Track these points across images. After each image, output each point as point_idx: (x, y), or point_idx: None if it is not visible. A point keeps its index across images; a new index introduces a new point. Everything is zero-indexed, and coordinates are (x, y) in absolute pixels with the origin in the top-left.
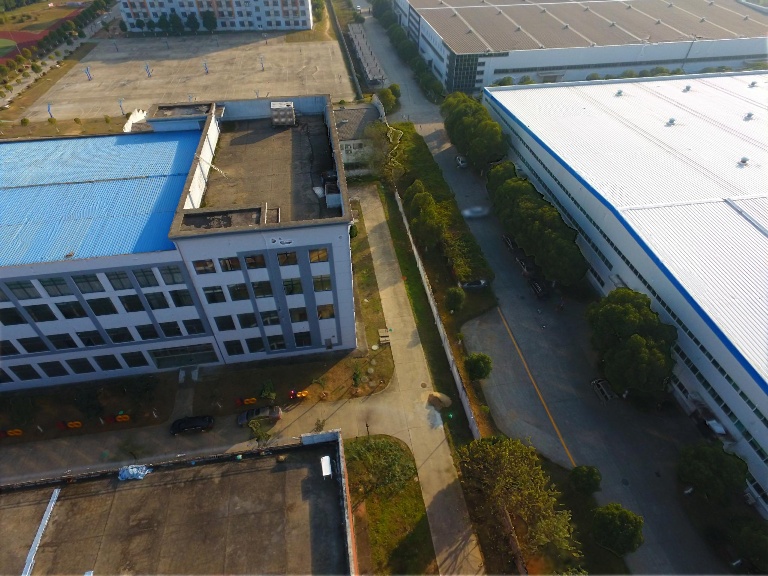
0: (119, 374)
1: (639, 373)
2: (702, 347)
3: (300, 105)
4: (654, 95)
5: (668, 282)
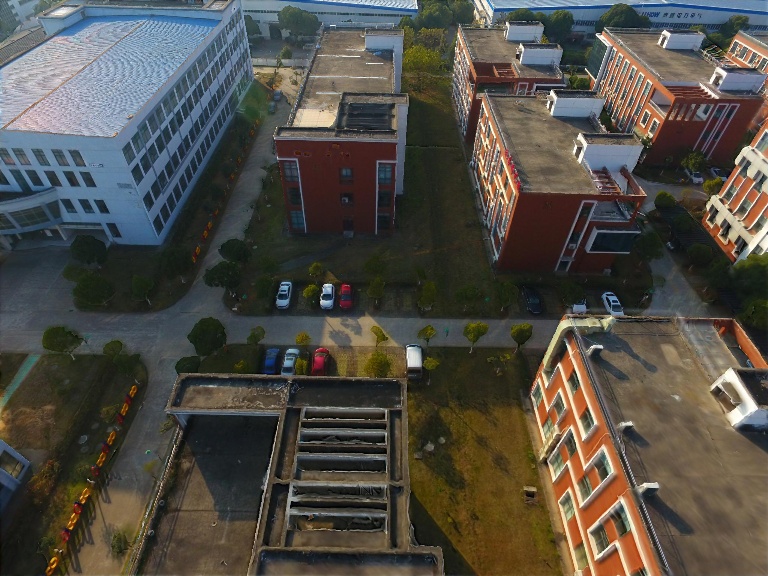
0: (226, 126)
1: (315, 22)
2: (312, 12)
3: None
4: None
5: (286, 2)
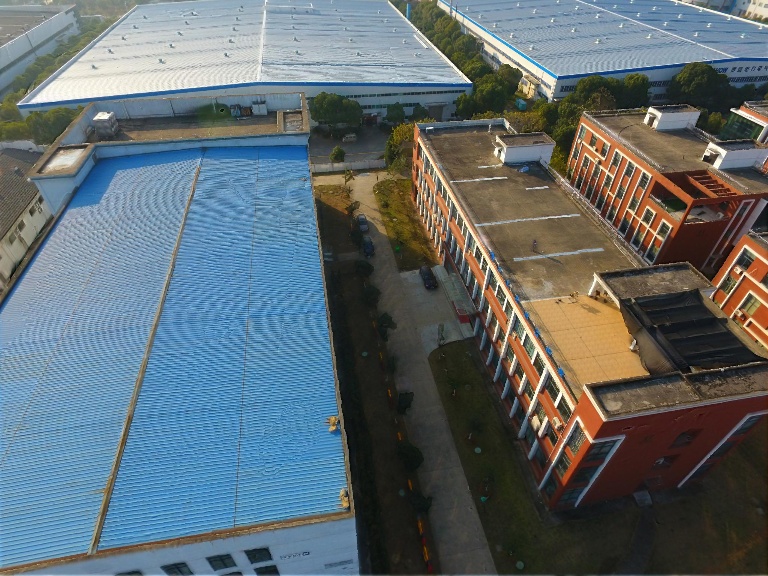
0: None
1: (358, 109)
2: (347, 96)
3: (90, 120)
4: (109, 60)
5: (315, 87)
